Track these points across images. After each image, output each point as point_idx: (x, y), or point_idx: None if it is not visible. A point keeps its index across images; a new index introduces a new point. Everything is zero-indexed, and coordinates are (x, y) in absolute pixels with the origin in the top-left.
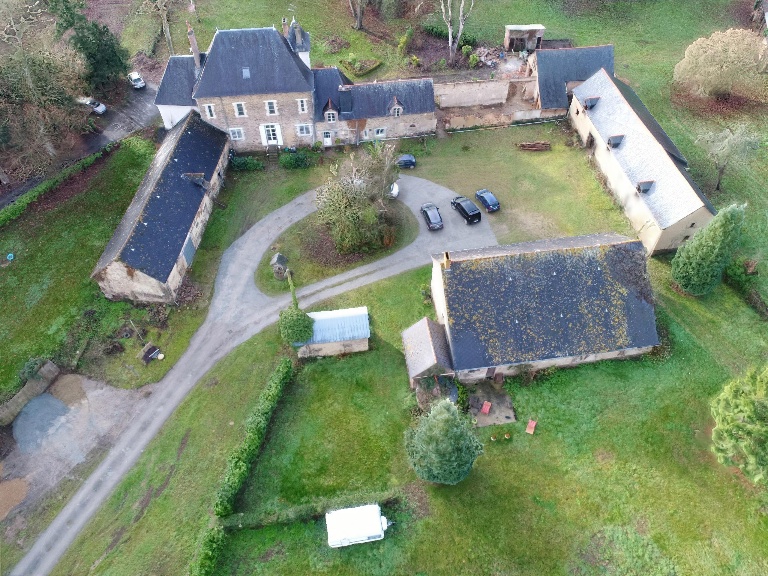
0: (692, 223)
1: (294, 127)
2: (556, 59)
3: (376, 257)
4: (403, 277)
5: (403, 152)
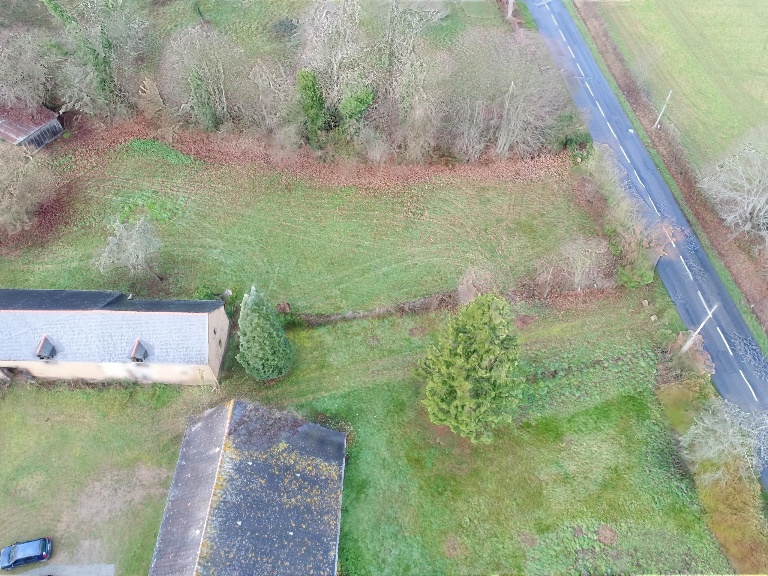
0: (213, 331)
1: None
2: None
3: None
4: None
5: None
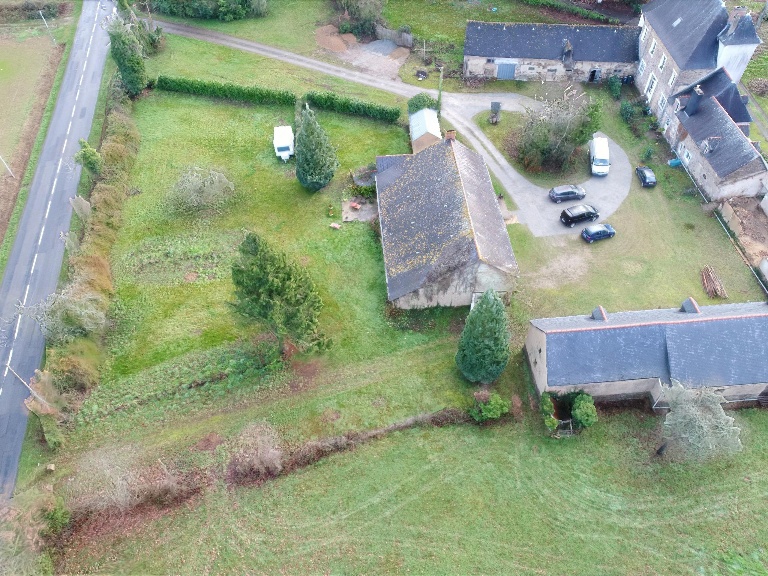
0: None
1: (661, 93)
2: None
3: (515, 165)
4: (492, 178)
5: (666, 179)
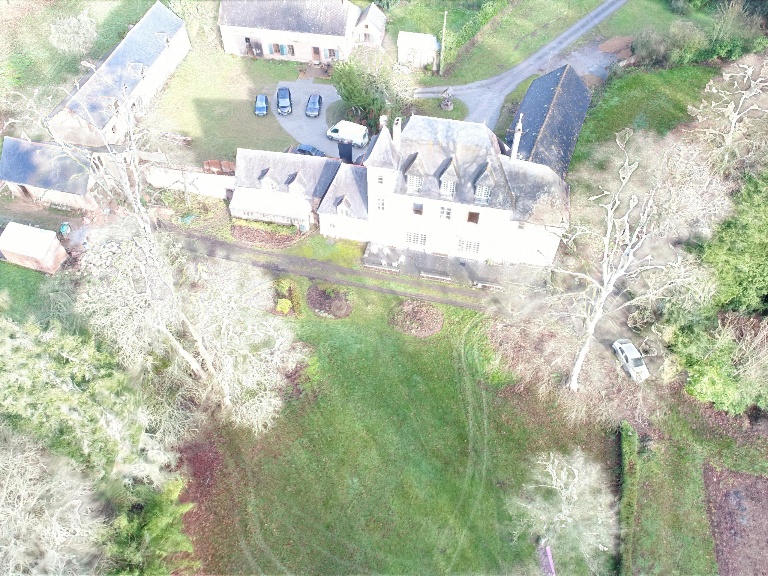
0: None
1: None
2: None
3: None
4: None
5: None
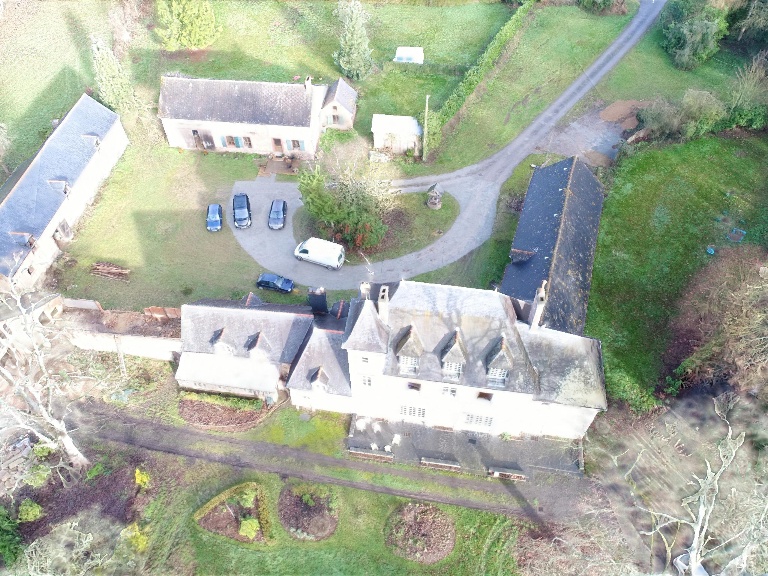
0: None
1: None
2: None
3: None
4: None
5: None
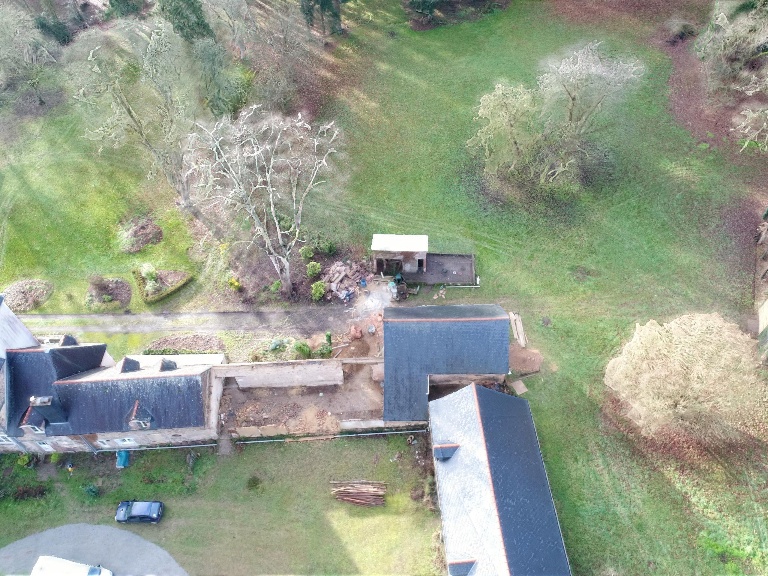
0: None
1: None
2: (415, 336)
3: None
4: None
5: (153, 483)
